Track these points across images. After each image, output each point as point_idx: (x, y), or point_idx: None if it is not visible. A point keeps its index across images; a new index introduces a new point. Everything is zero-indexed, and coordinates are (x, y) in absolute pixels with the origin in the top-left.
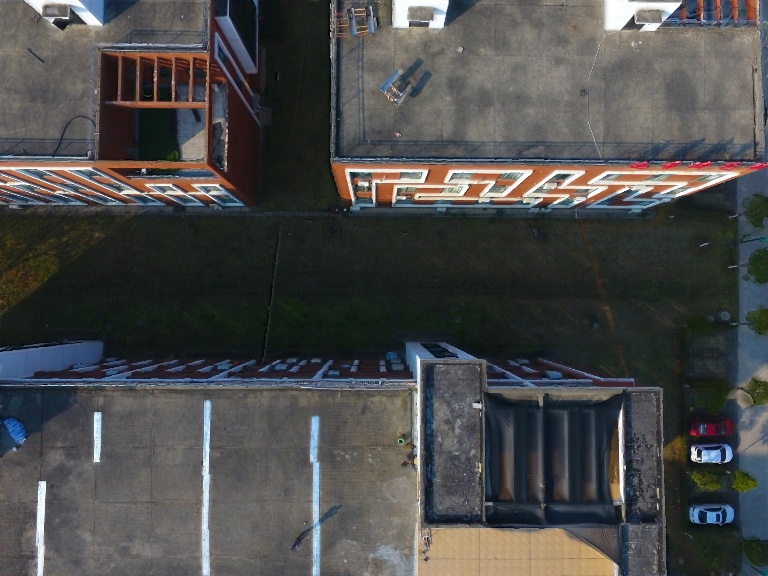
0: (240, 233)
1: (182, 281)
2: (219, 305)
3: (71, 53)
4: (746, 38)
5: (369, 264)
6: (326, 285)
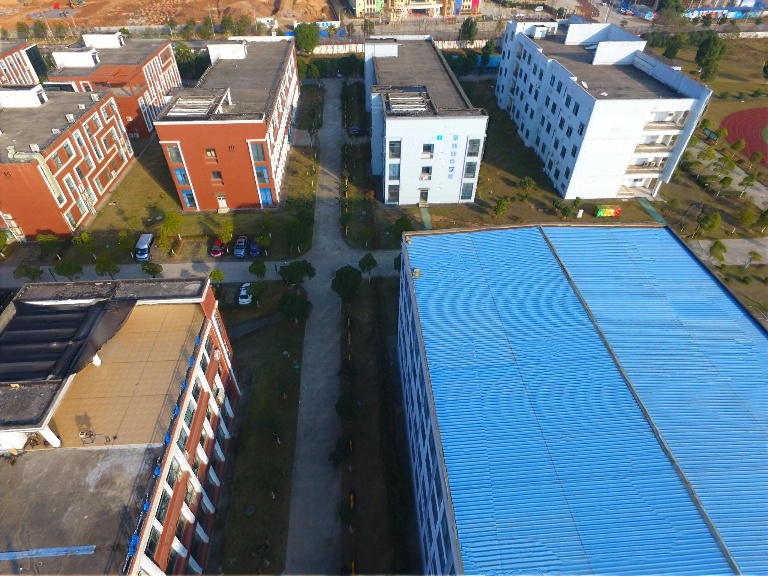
0: None
1: None
2: None
3: None
4: None
5: None
6: None
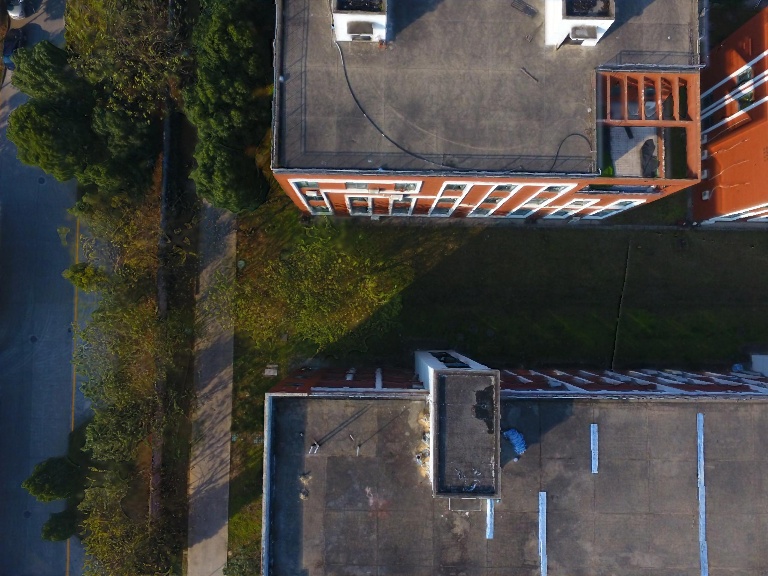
0: (590, 245)
1: (533, 292)
2: (569, 316)
3: (564, 72)
4: None
5: (718, 277)
6: (674, 297)
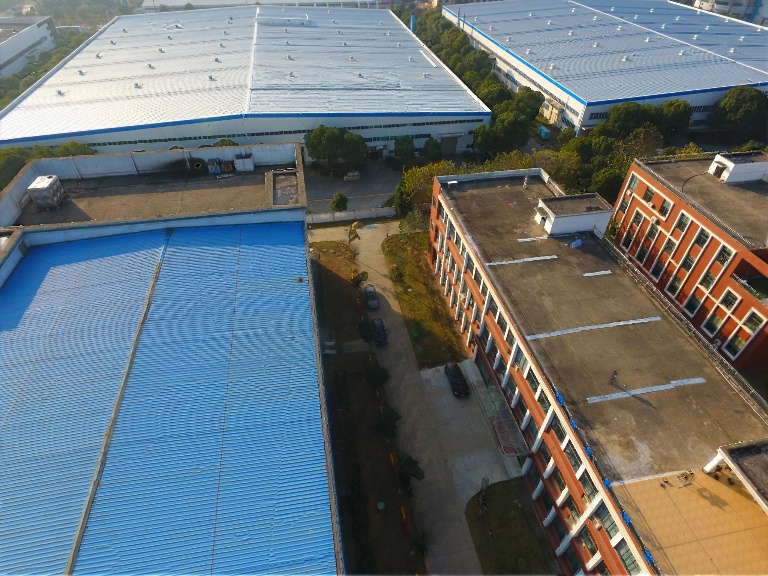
0: None
1: None
2: None
3: None
4: None
5: None
6: None
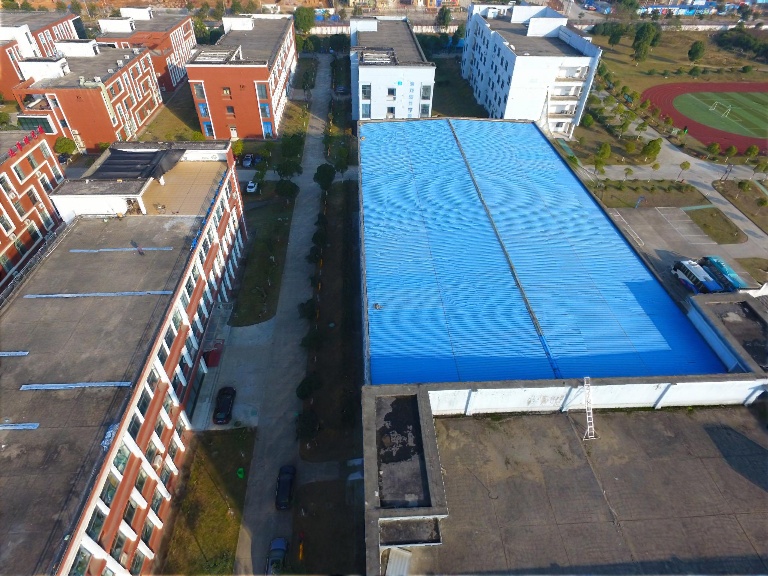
0: None
1: None
2: None
3: None
4: None
5: None
6: None
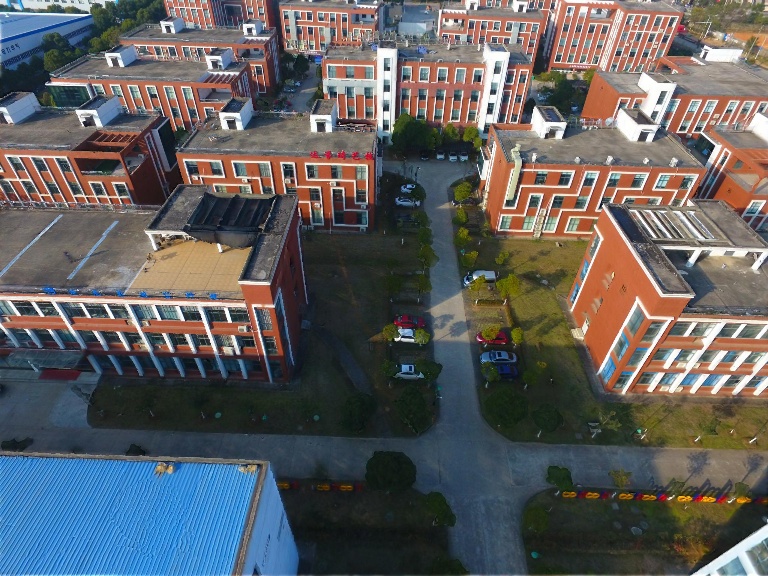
0: None
1: None
2: None
3: None
4: (371, 135)
5: None
6: None
